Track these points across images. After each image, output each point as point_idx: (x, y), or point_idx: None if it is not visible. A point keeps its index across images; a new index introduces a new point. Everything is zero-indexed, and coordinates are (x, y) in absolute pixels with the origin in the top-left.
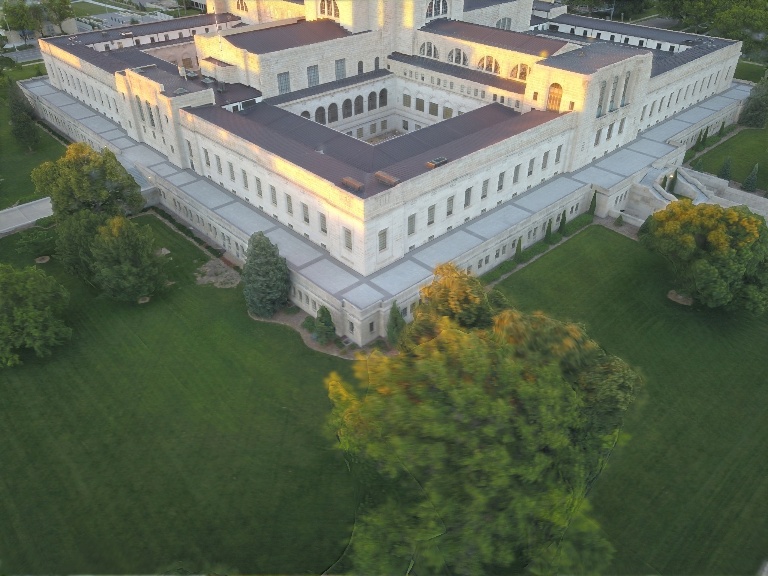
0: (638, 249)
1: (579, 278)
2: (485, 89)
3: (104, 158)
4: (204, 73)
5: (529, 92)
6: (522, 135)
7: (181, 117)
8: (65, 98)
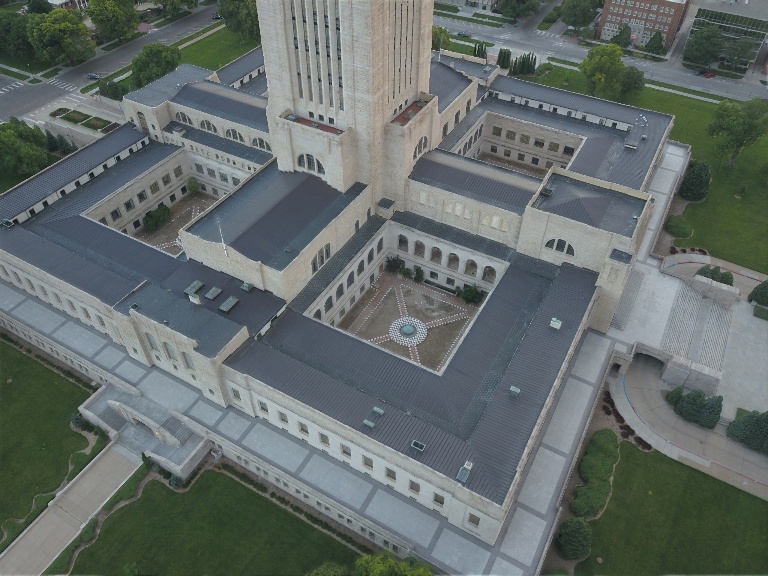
0: None
1: None
2: None
3: None
4: None
5: None
6: (230, 64)
7: None
8: None
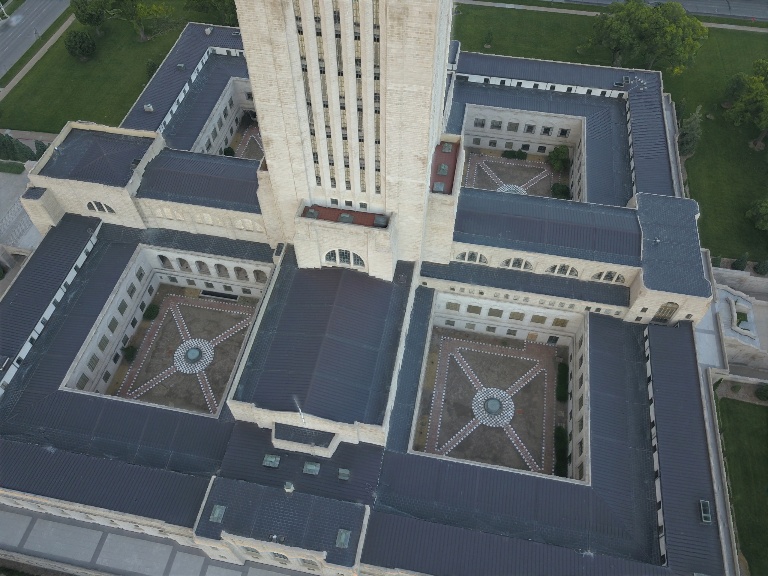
0: None
1: None
2: (576, 304)
3: None
4: (281, 448)
5: (637, 308)
6: None
7: (367, 569)
8: (1, 517)
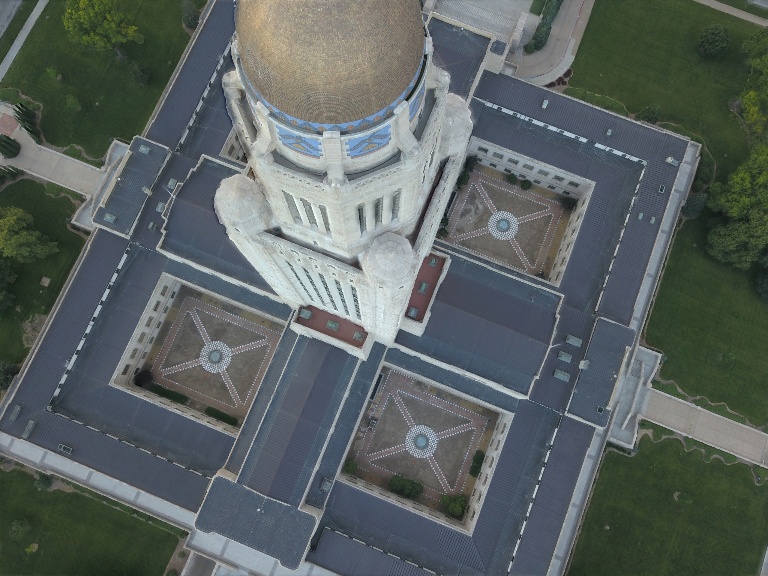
0: (155, 572)
1: (104, 540)
2: None
3: (5, 245)
4: None
5: None
6: (135, 489)
7: None
8: None
